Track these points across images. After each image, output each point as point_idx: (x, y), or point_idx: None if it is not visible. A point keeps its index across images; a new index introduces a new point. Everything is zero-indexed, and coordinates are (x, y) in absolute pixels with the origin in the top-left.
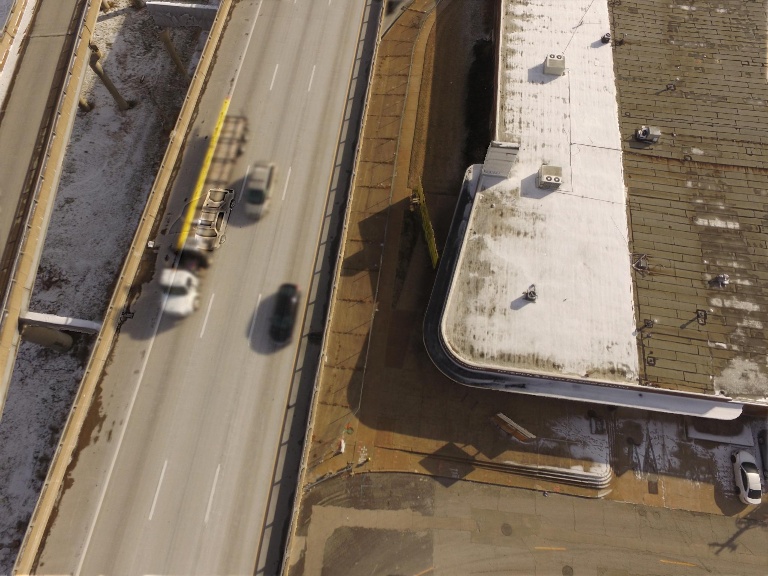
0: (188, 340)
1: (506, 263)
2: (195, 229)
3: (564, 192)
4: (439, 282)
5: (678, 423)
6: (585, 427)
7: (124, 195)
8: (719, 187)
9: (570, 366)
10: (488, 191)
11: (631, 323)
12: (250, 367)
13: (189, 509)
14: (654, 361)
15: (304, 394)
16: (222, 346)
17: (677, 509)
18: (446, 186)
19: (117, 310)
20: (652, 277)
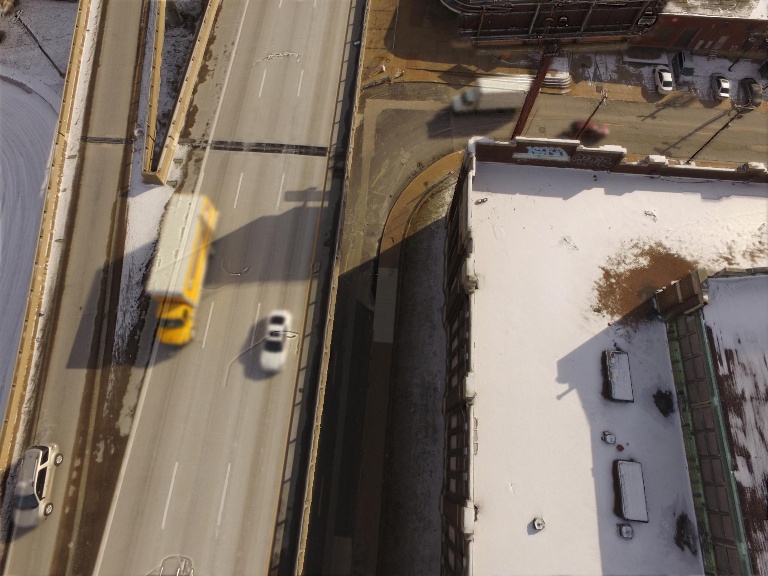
0: None
1: None
2: None
3: None
4: None
5: (616, 55)
6: None
7: None
8: None
9: None
10: None
11: None
12: None
13: (303, 2)
14: None
15: None
16: None
17: (616, 100)
18: None
19: None
20: None
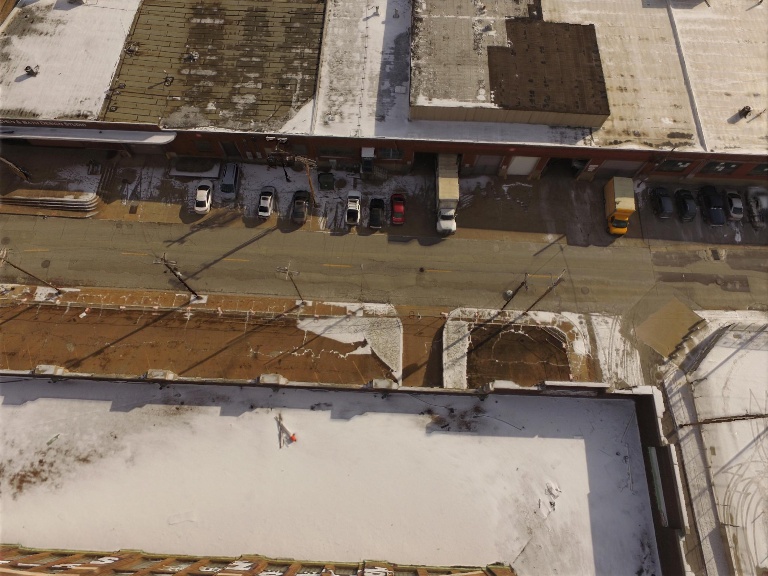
0: None
1: (23, 53)
2: None
3: (89, 5)
4: None
5: (166, 167)
6: (84, 171)
7: None
8: None
9: (46, 114)
10: (27, 7)
11: (106, 85)
12: None
13: None
14: (116, 109)
15: None
16: None
17: (148, 222)
18: None
19: None
20: (138, 57)
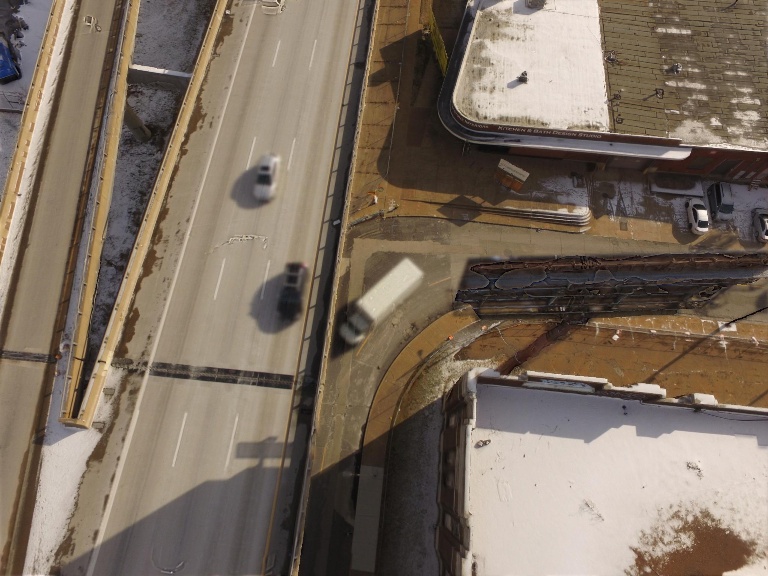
0: (263, 68)
1: (503, 58)
2: (261, 2)
3: (549, 10)
4: (449, 75)
5: (643, 183)
6: (569, 183)
7: (183, 34)
8: (675, 6)
9: (555, 124)
10: (487, 10)
11: (603, 96)
12: (312, 82)
13: (275, 163)
14: (622, 121)
15: (354, 97)
16: (290, 71)
17: (642, 240)
18: (451, 22)
19: (207, 50)
20: (620, 66)
